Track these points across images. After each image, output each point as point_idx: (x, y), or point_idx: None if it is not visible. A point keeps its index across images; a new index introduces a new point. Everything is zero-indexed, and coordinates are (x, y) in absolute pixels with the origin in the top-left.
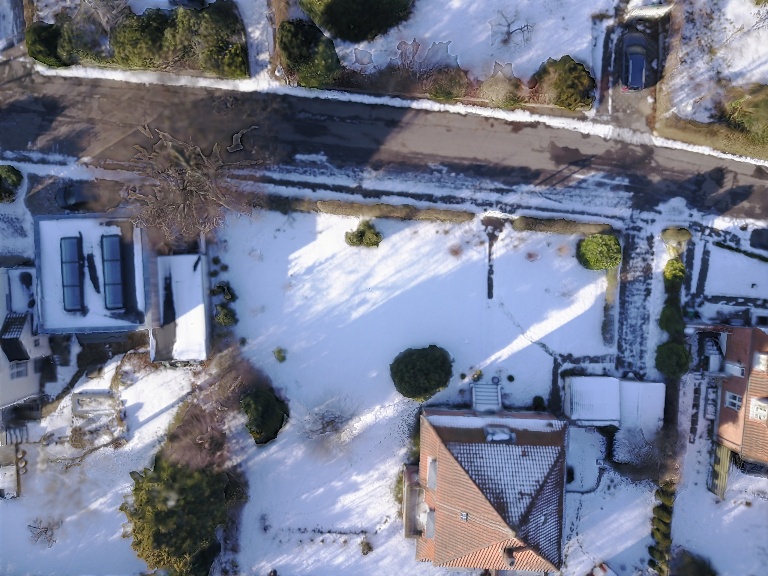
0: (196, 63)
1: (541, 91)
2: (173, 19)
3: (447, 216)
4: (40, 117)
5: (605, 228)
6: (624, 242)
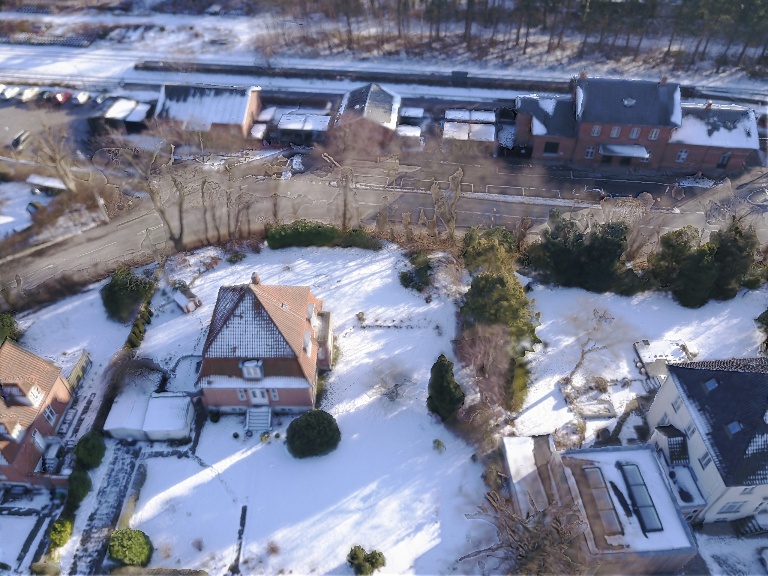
0: None
1: None
2: None
3: None
4: None
5: (118, 570)
6: (101, 567)
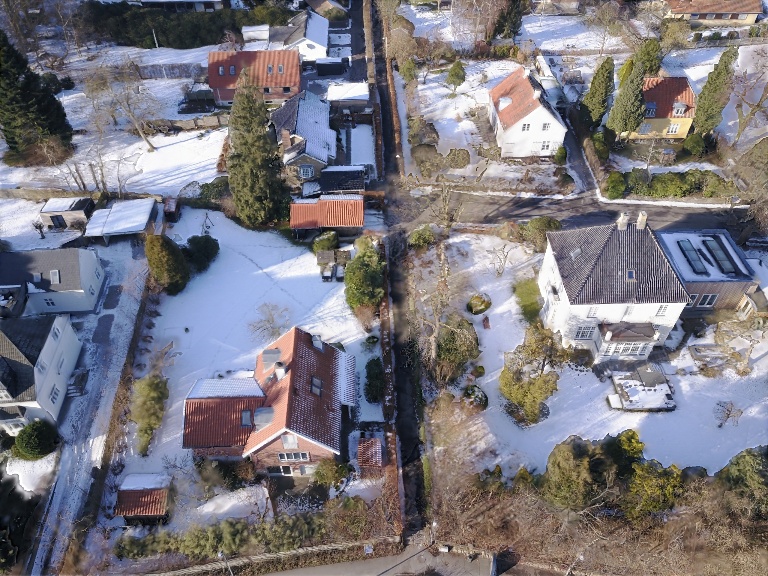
0: (698, 196)
1: None
2: (687, 174)
3: None
4: (609, 218)
5: None
6: None
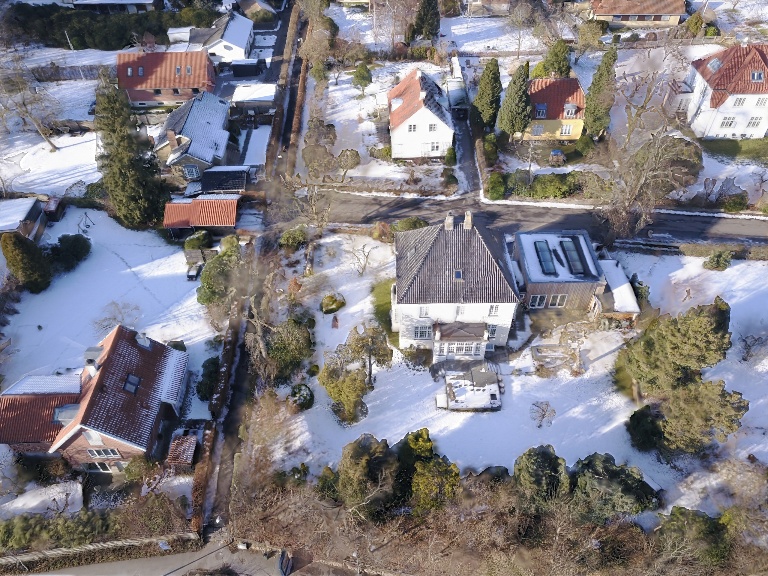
0: (579, 197)
1: None
2: None
3: None
4: (486, 219)
5: None
6: None
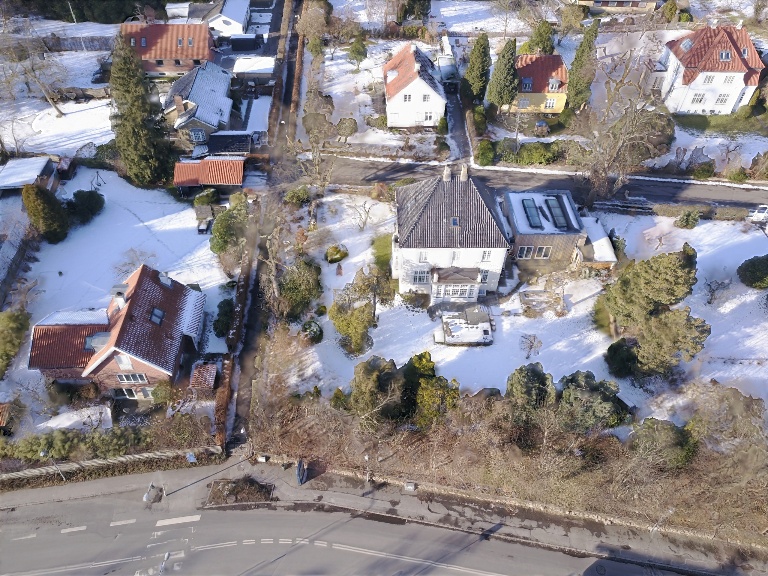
0: (562, 164)
1: (759, 167)
2: None
3: (734, 210)
4: None
5: None
6: None
